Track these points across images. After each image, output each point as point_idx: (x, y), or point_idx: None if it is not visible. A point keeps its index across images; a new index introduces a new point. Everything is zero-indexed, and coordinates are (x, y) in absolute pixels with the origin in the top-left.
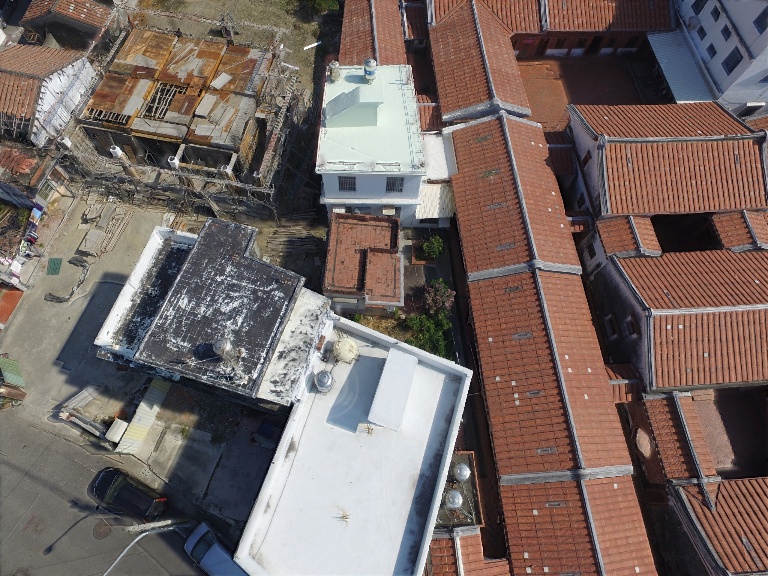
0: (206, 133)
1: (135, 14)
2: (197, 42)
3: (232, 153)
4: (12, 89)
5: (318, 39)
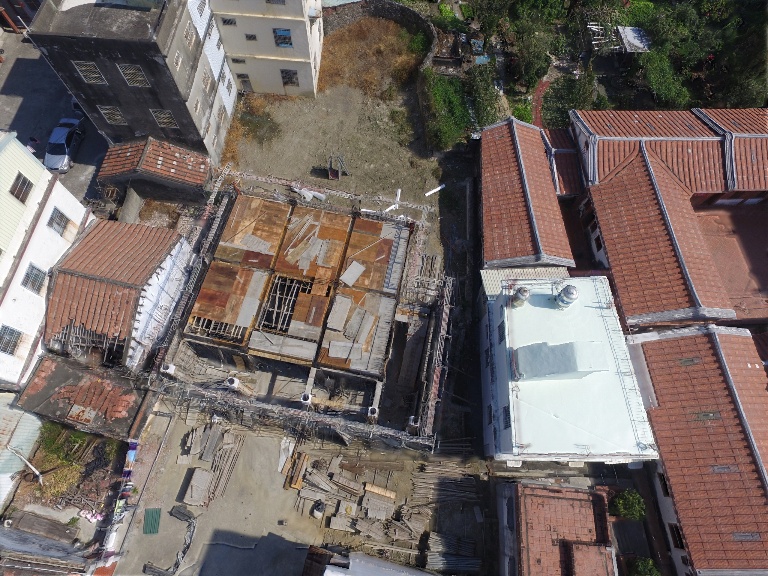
0: (343, 354)
1: (225, 150)
2: (317, 214)
3: (376, 381)
4: (103, 300)
5: (440, 181)
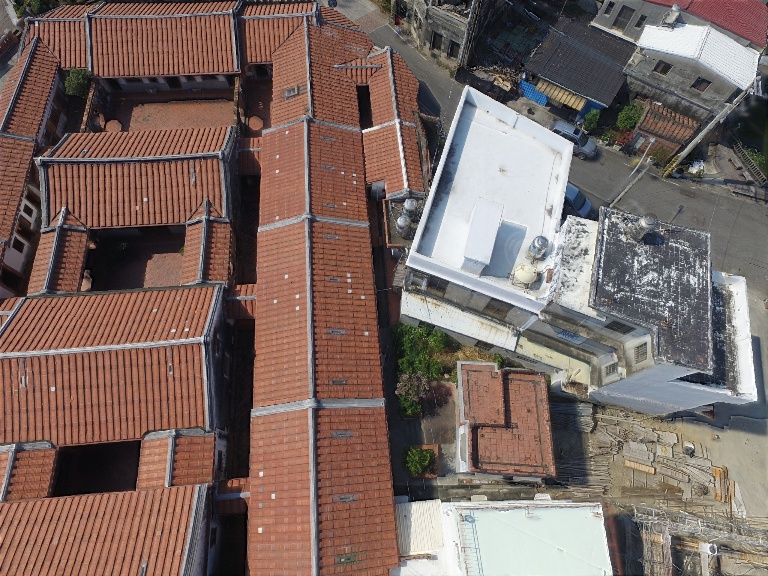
0: None
1: None
2: None
3: None
4: None
5: None
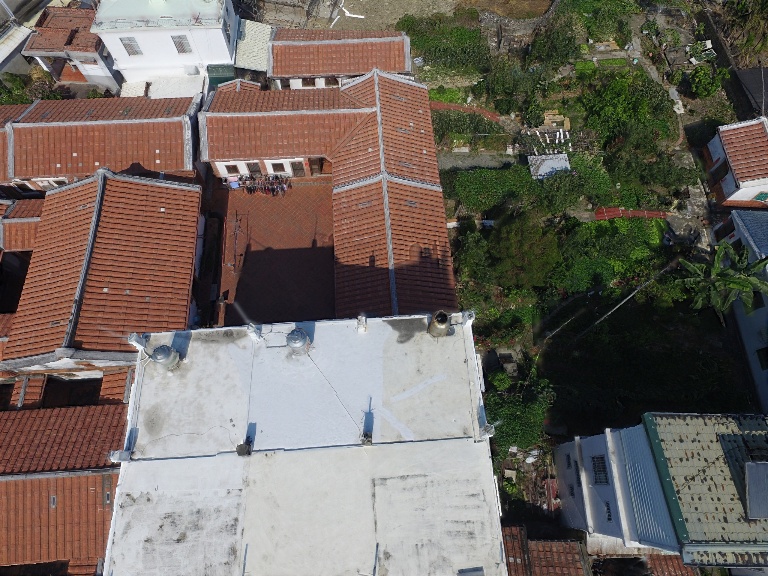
0: None
1: None
2: None
3: None
4: None
5: None
